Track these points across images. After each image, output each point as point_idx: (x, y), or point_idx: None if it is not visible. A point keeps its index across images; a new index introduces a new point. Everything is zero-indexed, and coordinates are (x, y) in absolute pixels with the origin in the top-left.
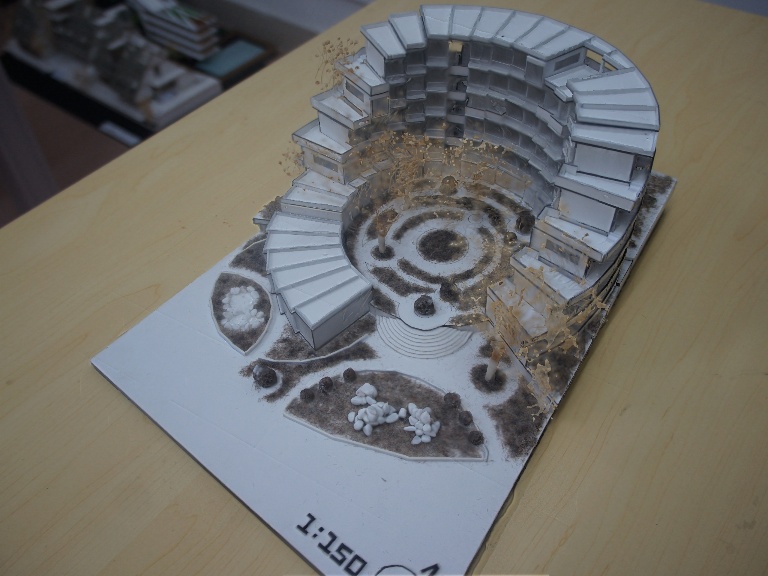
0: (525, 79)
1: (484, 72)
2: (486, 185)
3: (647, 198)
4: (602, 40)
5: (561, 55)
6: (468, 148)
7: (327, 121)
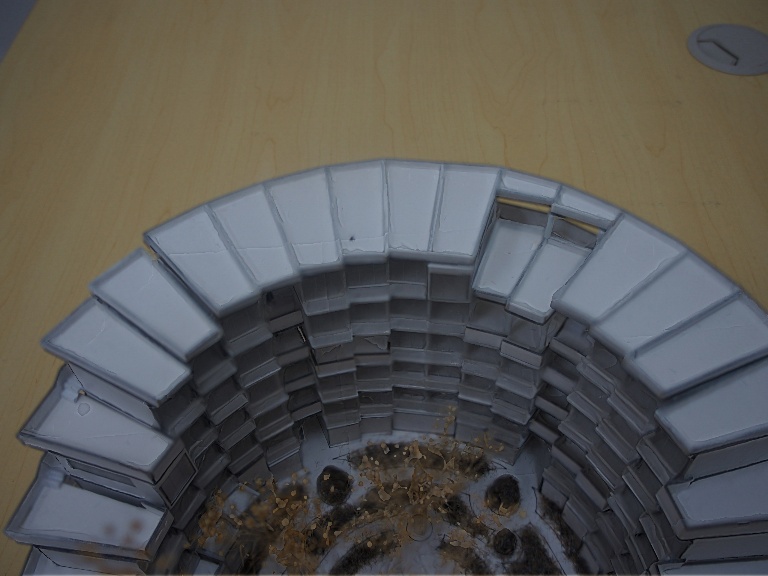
0: (430, 298)
1: (340, 310)
2: (383, 441)
3: None
4: (522, 174)
5: (482, 236)
6: (333, 408)
7: (70, 558)
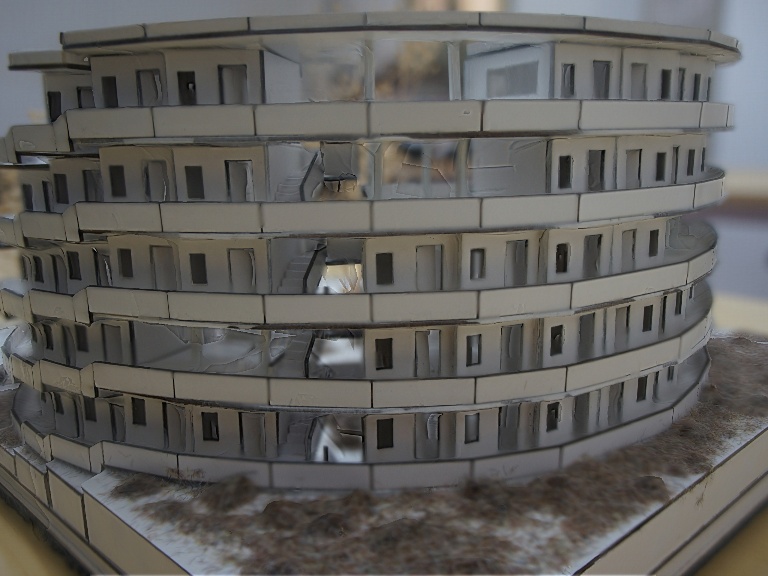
0: None
1: None
2: None
3: (287, 563)
4: None
5: (499, 51)
6: None
7: None
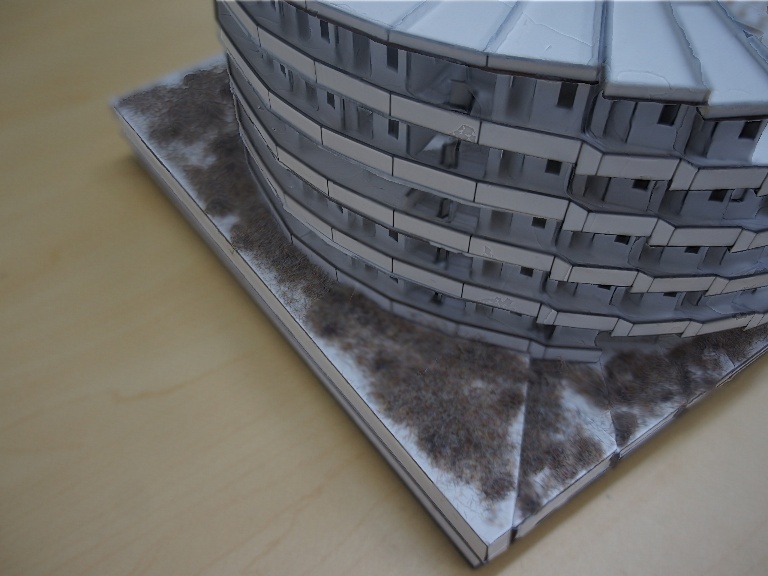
0: None
1: None
2: None
3: (198, 78)
4: None
5: None
6: None
7: None
